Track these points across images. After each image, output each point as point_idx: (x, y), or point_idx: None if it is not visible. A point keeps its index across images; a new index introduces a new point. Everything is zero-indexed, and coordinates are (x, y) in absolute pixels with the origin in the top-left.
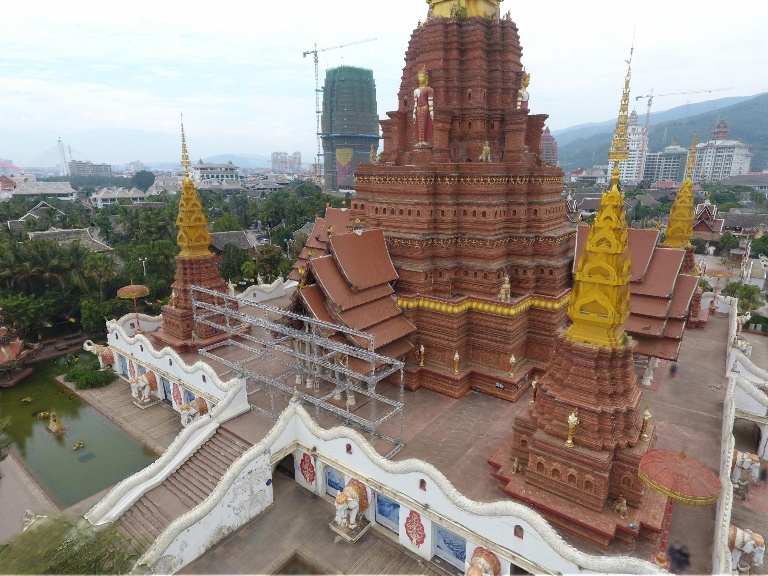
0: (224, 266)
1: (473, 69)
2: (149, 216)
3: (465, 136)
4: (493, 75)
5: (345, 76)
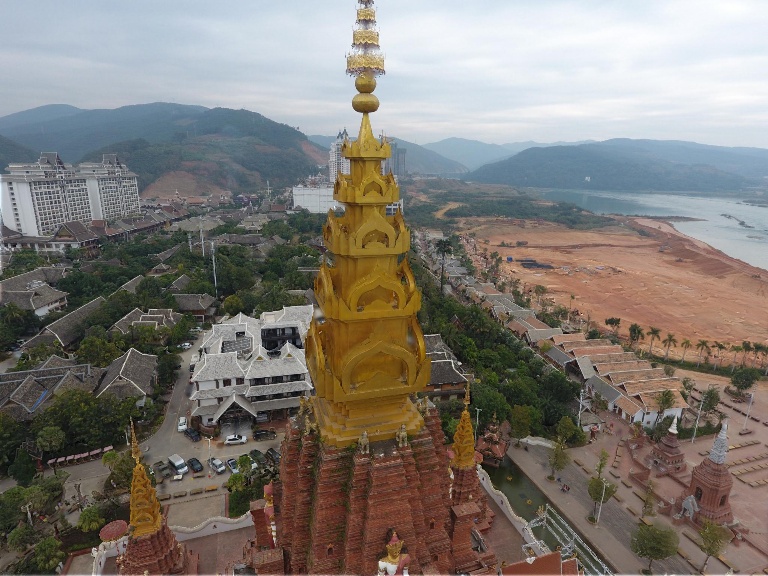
0: None
1: None
2: None
3: None
4: None
5: None
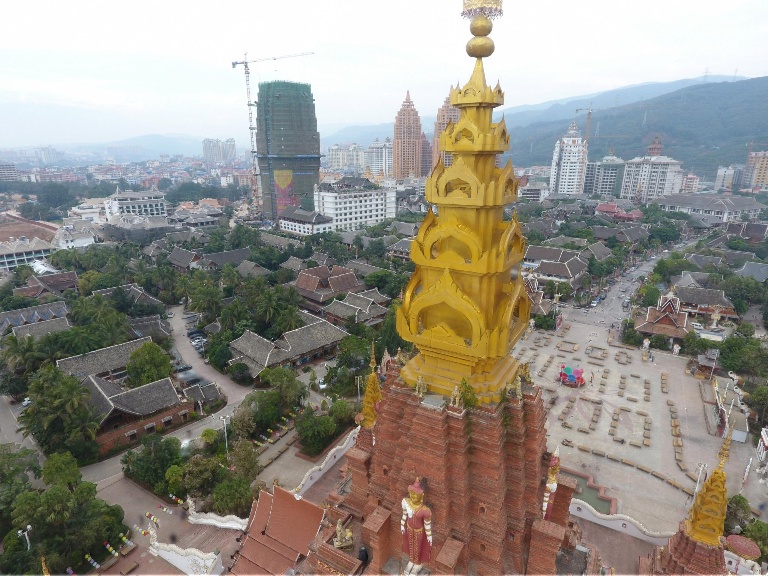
0: (143, 469)
1: (487, 479)
2: (41, 385)
3: (476, 559)
4: (513, 473)
5: (280, 92)
